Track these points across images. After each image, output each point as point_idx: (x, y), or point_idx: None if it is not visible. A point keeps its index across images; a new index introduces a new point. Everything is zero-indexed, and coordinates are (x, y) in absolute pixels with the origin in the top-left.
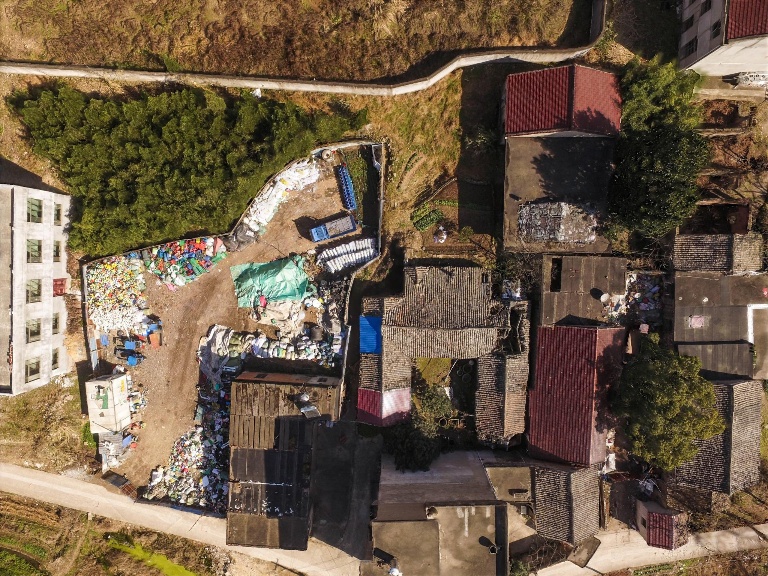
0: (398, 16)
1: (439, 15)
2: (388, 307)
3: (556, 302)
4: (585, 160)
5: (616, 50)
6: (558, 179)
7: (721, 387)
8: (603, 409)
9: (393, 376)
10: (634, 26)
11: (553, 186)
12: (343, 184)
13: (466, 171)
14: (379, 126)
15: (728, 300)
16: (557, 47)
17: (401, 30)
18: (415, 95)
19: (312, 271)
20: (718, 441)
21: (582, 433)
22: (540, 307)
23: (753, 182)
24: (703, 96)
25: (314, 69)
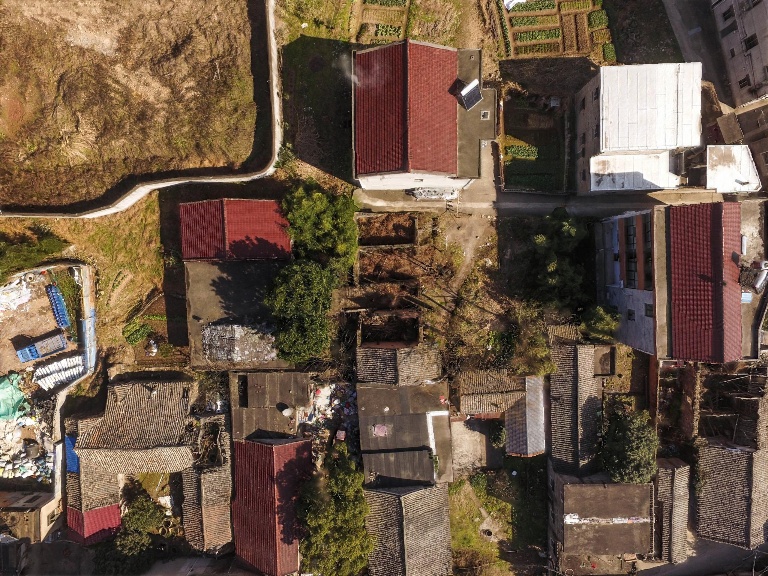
0: (90, 143)
1: (128, 142)
2: (84, 429)
3: (245, 417)
4: (261, 281)
5: (303, 168)
6: (237, 300)
7: (393, 497)
8: (290, 521)
9: (96, 494)
10: (318, 145)
11: (233, 307)
12: (52, 304)
13: (171, 286)
14: (83, 247)
15: (408, 408)
16: (240, 169)
17: (96, 155)
18: (115, 216)
19: (28, 389)
20: (396, 549)
21: (270, 546)
22: (232, 422)
23: (443, 287)
24: (389, 208)
25: (11, 196)
